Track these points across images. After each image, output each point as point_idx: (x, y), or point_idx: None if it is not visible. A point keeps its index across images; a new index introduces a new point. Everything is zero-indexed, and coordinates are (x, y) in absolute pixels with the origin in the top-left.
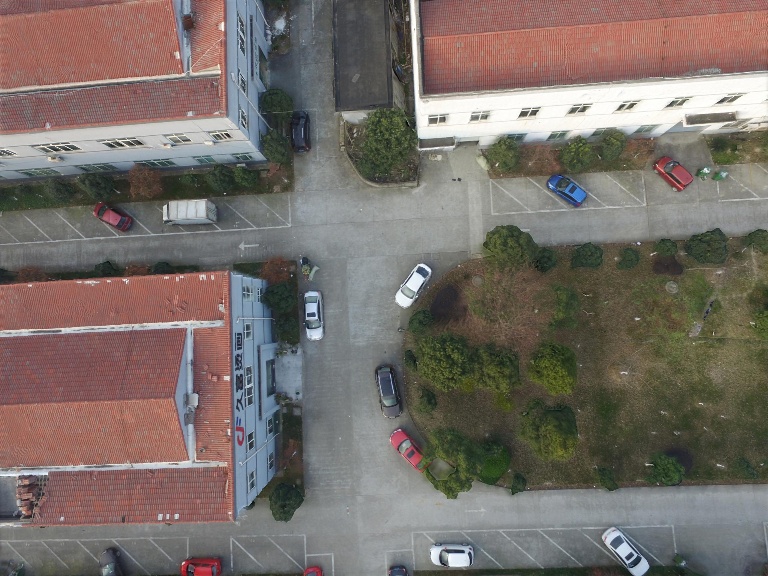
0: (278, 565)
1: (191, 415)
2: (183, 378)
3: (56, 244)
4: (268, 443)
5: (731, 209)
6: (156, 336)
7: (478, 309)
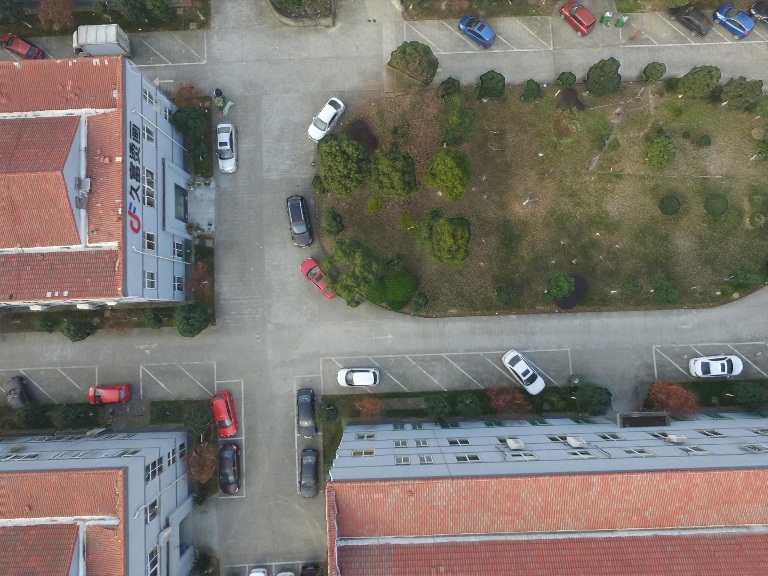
0: (188, 392)
1: (84, 200)
2: (75, 161)
3: None
4: (175, 262)
5: (632, 54)
6: (49, 122)
7: (389, 143)
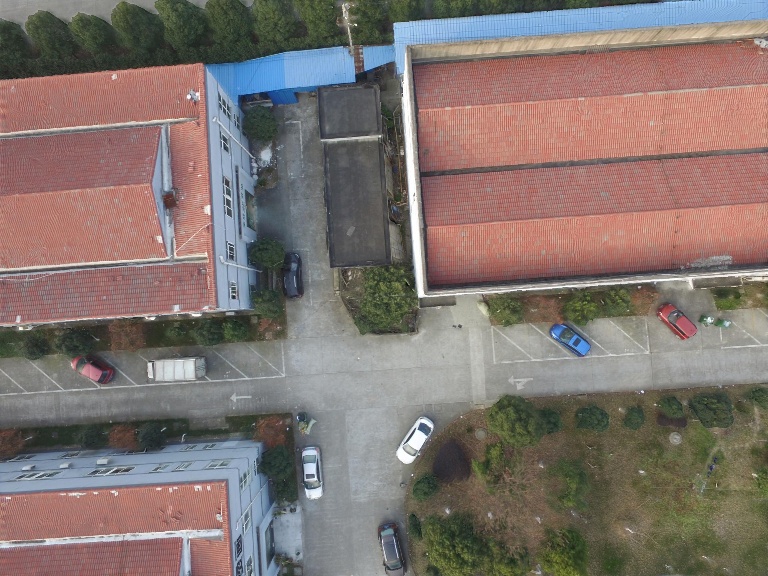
0: None
1: None
2: None
3: (32, 396)
4: None
5: (734, 356)
6: (150, 548)
7: (482, 465)
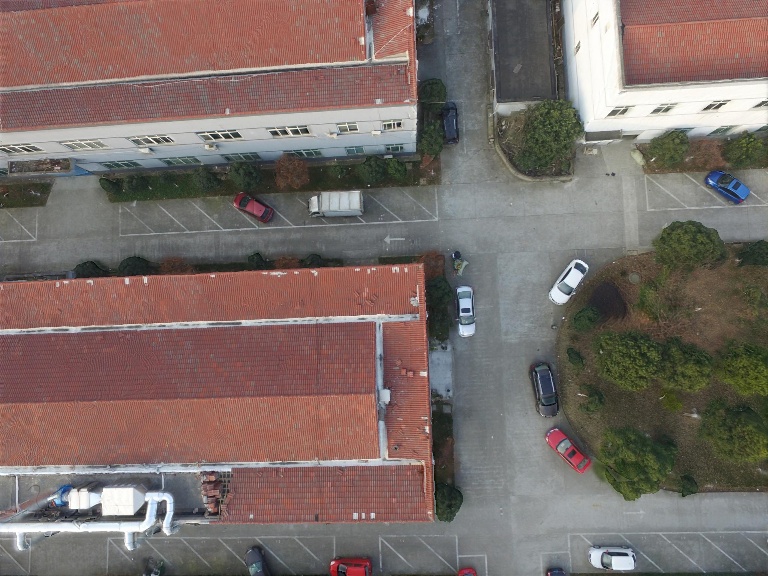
0: (429, 566)
1: (381, 411)
2: None
3: (193, 235)
4: None
5: None
6: (344, 330)
7: (637, 307)
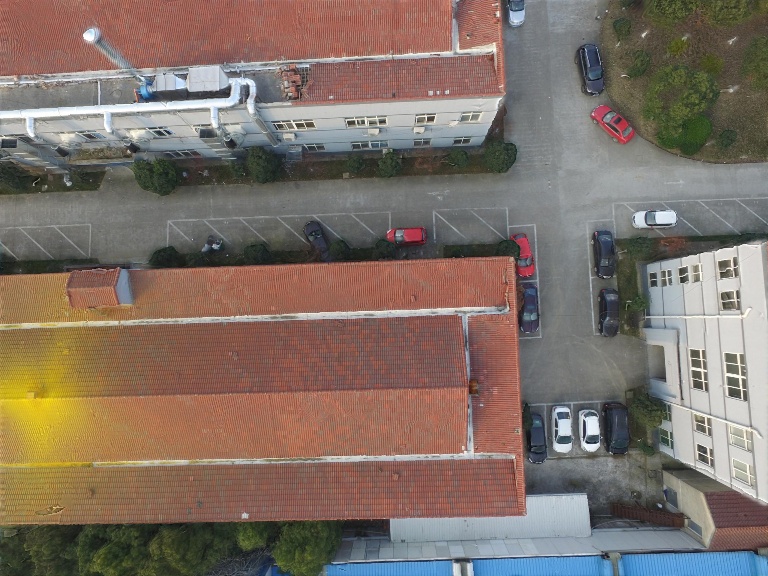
0: (481, 236)
1: (452, 10)
2: None
3: None
4: None
5: None
6: None
7: None
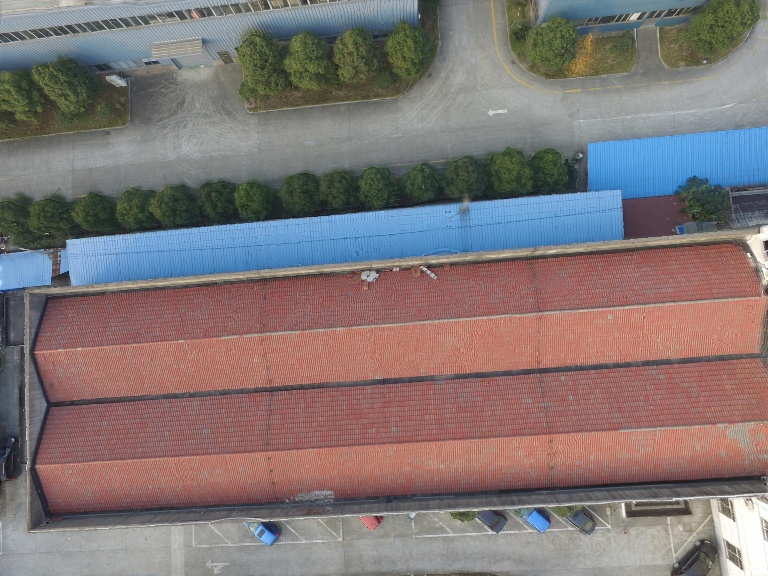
0: None
1: None
2: None
3: None
4: None
5: (425, 545)
6: None
7: None
